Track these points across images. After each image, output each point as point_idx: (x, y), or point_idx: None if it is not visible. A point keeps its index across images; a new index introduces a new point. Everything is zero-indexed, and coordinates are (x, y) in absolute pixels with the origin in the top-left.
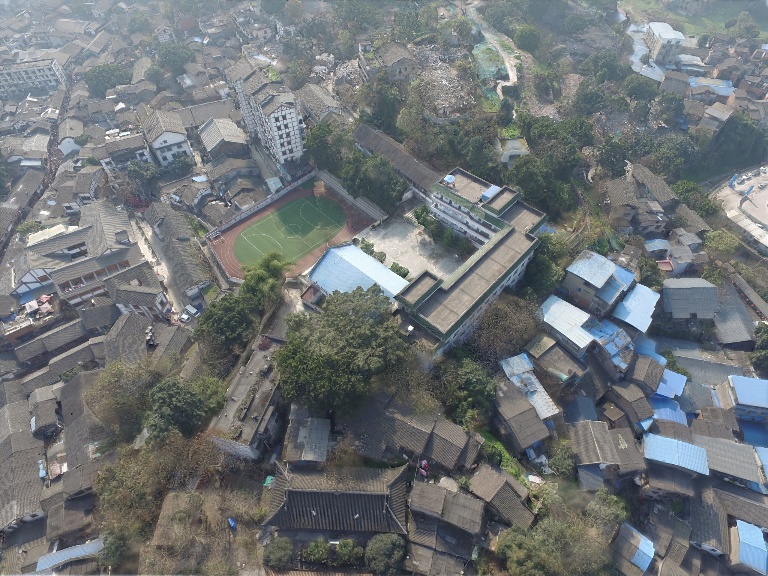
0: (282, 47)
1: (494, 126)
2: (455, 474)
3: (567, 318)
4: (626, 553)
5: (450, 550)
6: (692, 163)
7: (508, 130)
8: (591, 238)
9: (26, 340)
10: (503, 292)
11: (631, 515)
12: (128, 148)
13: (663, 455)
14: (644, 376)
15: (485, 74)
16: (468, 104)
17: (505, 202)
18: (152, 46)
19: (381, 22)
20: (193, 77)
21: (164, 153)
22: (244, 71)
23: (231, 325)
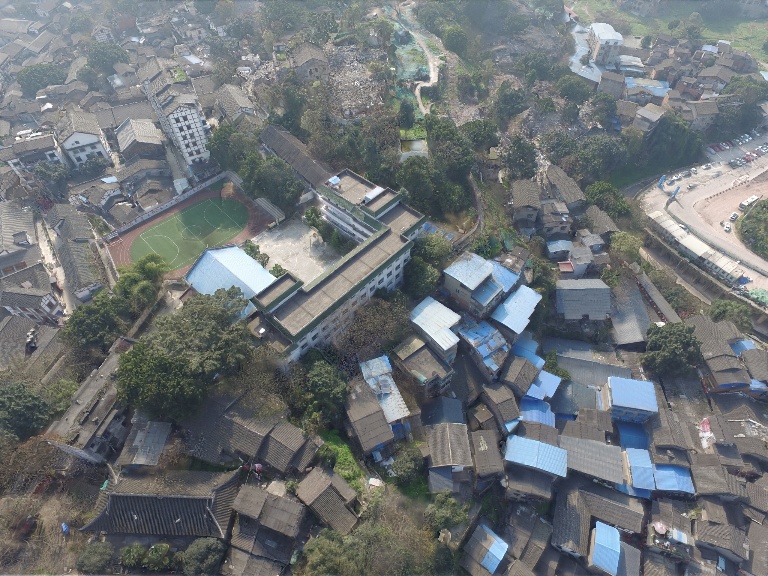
0: None
1: (395, 127)
2: (289, 477)
3: (438, 320)
4: (476, 555)
5: (268, 554)
6: (619, 164)
7: (416, 131)
8: (482, 239)
9: None
10: (375, 294)
11: (495, 517)
12: (36, 149)
13: (523, 457)
14: (515, 378)
15: (404, 75)
16: (375, 105)
17: (384, 204)
18: None
19: (306, 22)
20: (122, 77)
21: (77, 154)
22: (151, 71)
23: (93, 328)
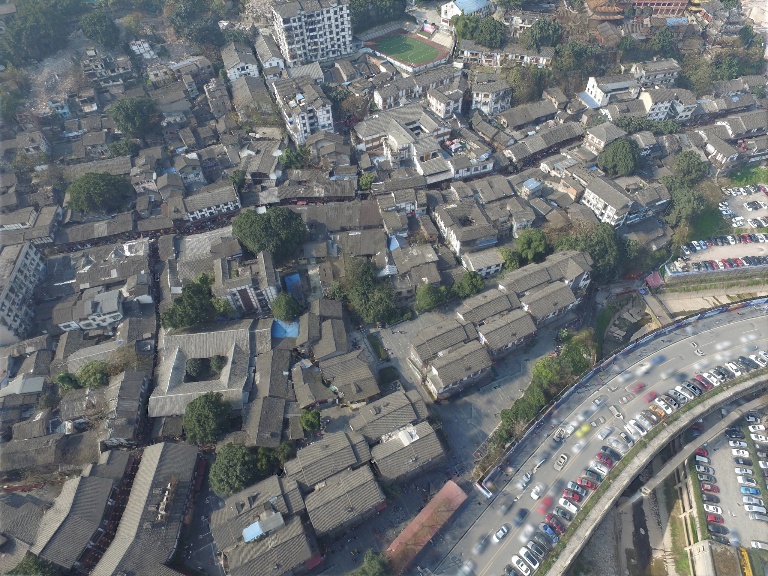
0: (161, 58)
1: None
2: None
3: None
4: None
5: None
6: None
7: None
8: None
9: None
10: None
11: None
12: None
13: None
14: None
15: None
16: None
17: None
18: None
19: None
20: (181, 103)
21: None
22: (292, 7)
23: None
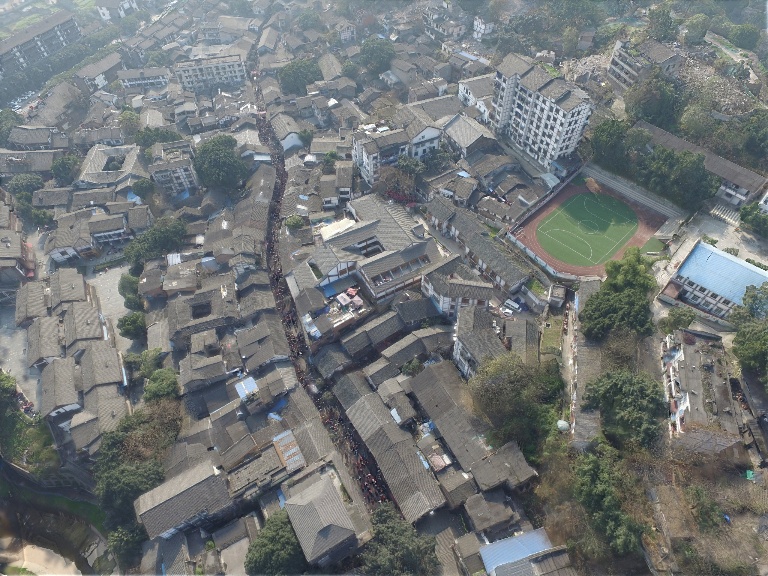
0: (481, 44)
1: None
2: None
3: None
4: None
5: None
6: None
7: None
8: None
9: (343, 333)
10: None
11: None
12: (395, 143)
13: None
14: None
15: None
16: (748, 101)
17: None
18: (331, 43)
19: (605, 19)
20: (402, 73)
21: (418, 148)
22: (519, 67)
23: (639, 319)
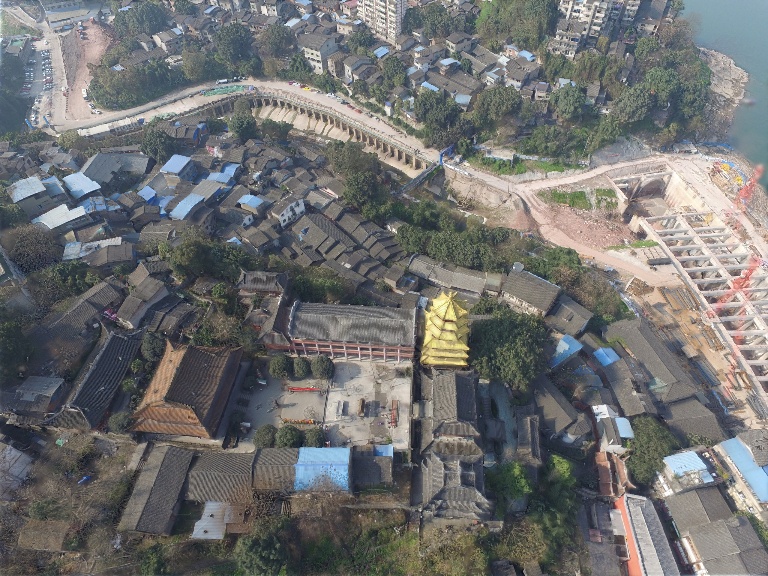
0: None
1: None
2: None
3: (57, 216)
4: None
5: (171, 306)
6: None
7: None
8: (1, 189)
9: None
10: (2, 244)
11: None
12: None
13: (184, 211)
14: (132, 201)
15: None
16: None
17: None
18: None
19: None
20: None
21: None
22: None
23: None
